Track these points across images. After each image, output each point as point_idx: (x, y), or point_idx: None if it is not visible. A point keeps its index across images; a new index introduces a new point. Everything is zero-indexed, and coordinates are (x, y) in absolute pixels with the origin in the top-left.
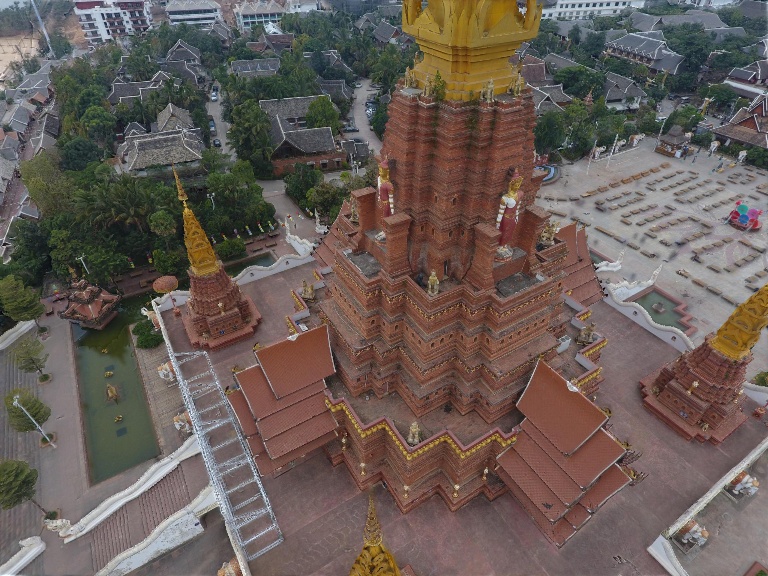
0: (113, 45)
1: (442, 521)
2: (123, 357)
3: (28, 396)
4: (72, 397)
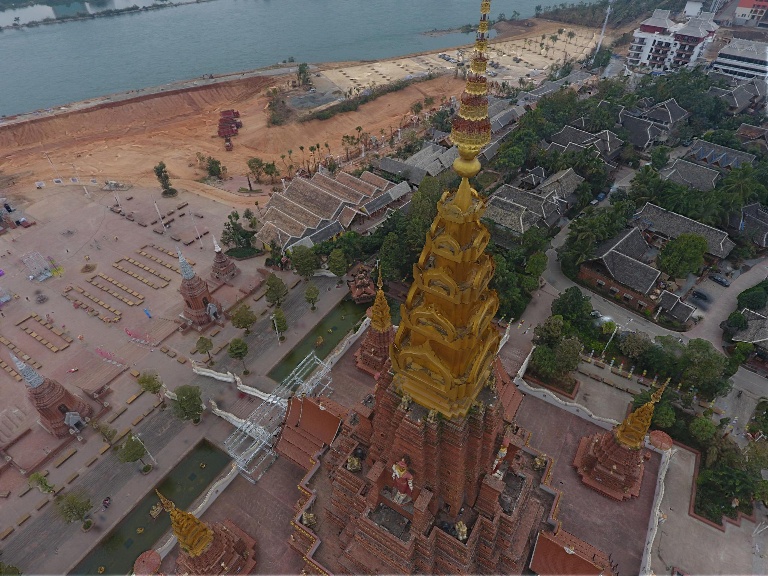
0: (621, 80)
1: (294, 574)
2: (345, 328)
3: (282, 317)
4: (309, 328)
